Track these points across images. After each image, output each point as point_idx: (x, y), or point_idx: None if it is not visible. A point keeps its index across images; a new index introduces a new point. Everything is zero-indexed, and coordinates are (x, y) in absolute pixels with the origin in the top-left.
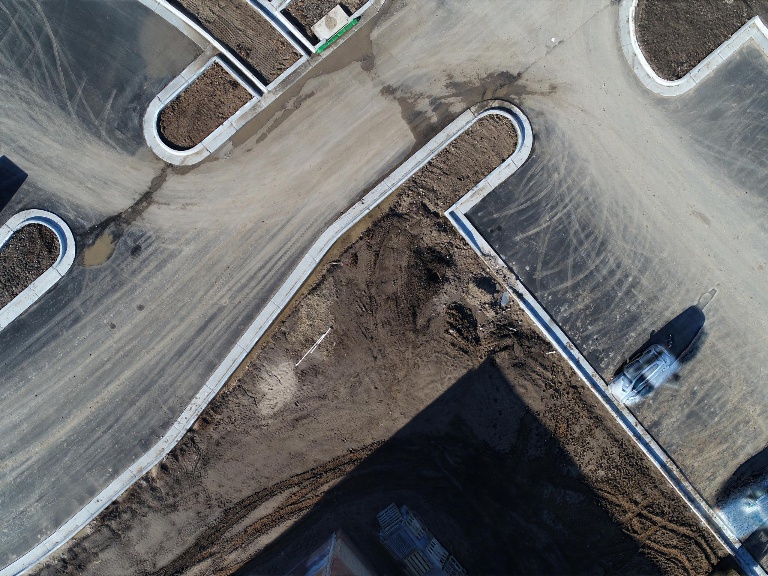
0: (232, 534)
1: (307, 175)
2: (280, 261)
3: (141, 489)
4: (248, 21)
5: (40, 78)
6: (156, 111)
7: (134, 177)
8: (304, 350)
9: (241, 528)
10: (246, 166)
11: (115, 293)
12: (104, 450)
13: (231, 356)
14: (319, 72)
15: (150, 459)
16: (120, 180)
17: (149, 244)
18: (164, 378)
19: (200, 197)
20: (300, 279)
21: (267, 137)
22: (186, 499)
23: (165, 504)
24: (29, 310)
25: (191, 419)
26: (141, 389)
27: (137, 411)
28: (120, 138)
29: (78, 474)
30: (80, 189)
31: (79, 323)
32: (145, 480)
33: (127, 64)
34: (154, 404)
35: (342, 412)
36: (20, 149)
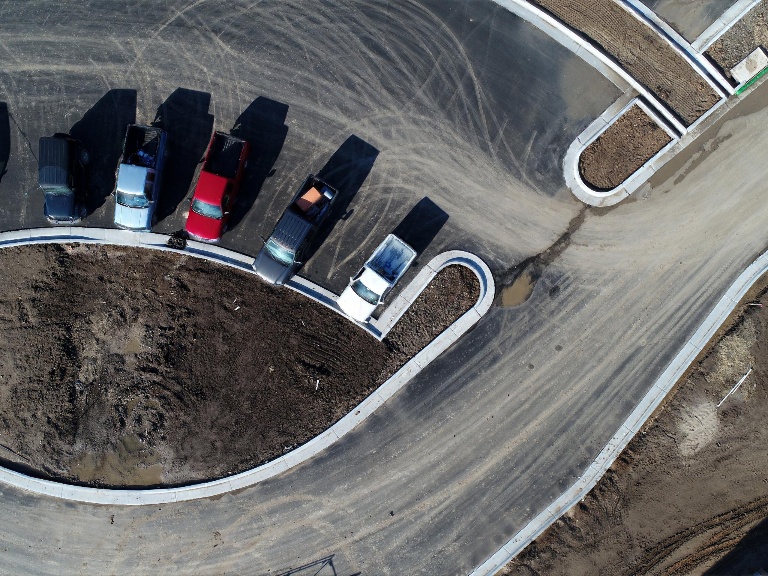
0: (653, 574)
1: (724, 217)
2: (697, 302)
3: (559, 529)
4: (668, 63)
5: (462, 120)
6: (577, 153)
7: (553, 218)
8: (725, 391)
9: (662, 568)
10: (664, 207)
11: (533, 334)
12: (522, 490)
13: (649, 397)
14: (736, 114)
15: (568, 499)
16: (539, 221)
17: (567, 285)
18: (582, 418)
19: (618, 238)
20: (718, 320)
21: (684, 179)
22: (607, 539)
23: (585, 544)
24: (448, 350)
25: (609, 459)
26: (559, 429)
27: (555, 451)
28: (540, 179)
29: (496, 514)
30: (500, 230)
31: (497, 363)
32: (562, 520)
33: (548, 106)
34: (572, 444)
35: (764, 453)
36: (442, 190)
